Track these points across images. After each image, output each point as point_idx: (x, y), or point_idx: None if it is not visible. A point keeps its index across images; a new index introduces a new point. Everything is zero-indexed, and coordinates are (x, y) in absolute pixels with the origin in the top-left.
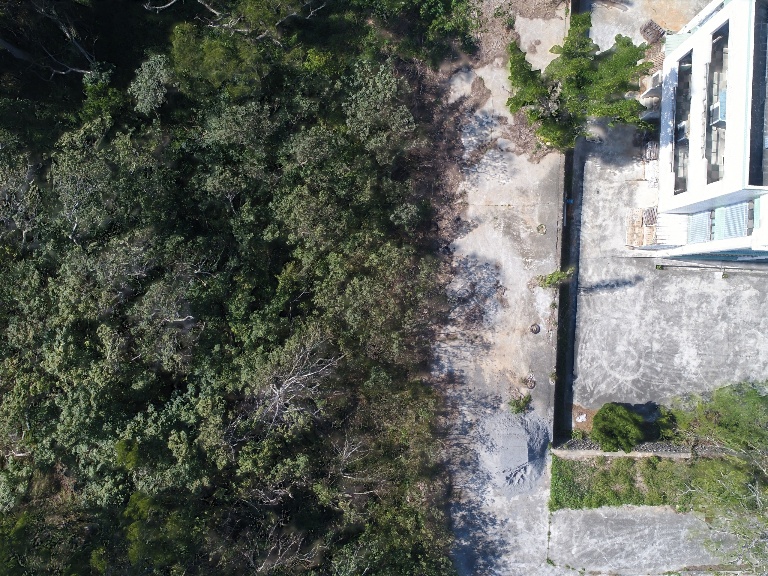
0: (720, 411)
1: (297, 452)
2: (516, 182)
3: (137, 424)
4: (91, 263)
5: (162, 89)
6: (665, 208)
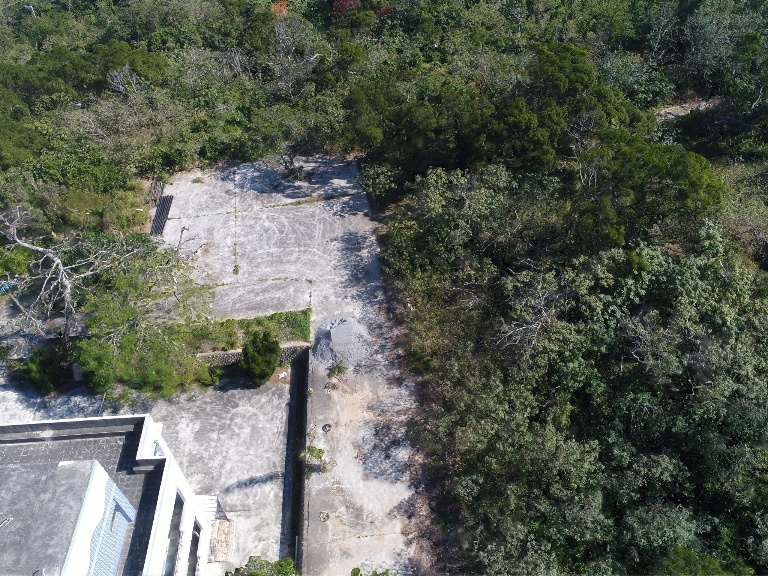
0: (175, 374)
1: None
2: (354, 564)
3: (642, 287)
4: (742, 388)
5: (763, 532)
6: (208, 524)
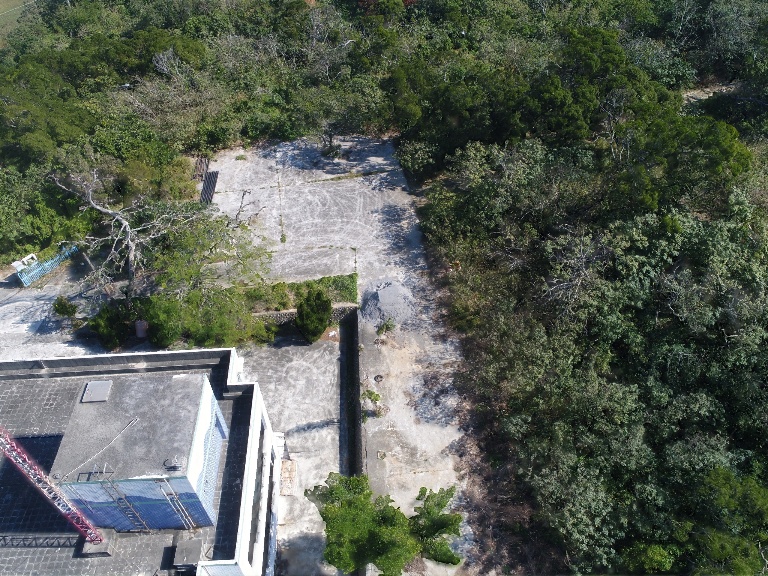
0: (235, 329)
1: (551, 267)
2: (411, 495)
3: (675, 248)
4: None
5: None
6: None
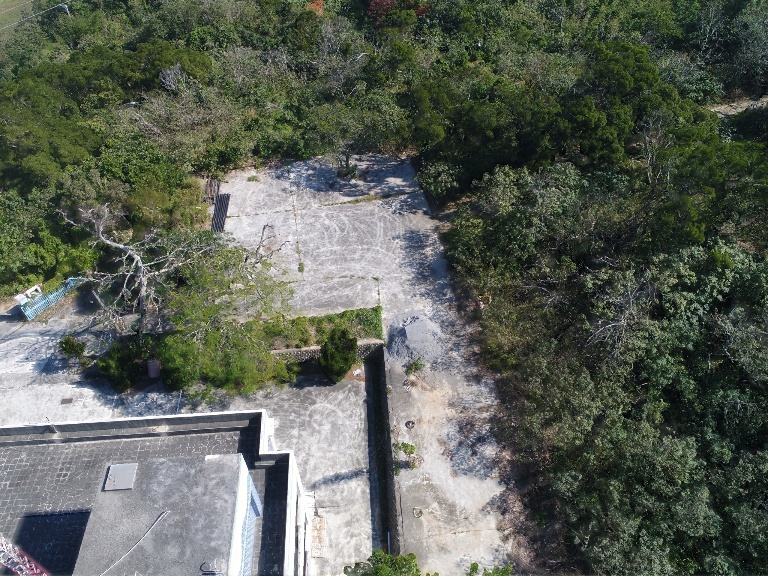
0: (255, 371)
1: (590, 302)
2: (452, 559)
3: (725, 284)
4: None
5: None
6: None
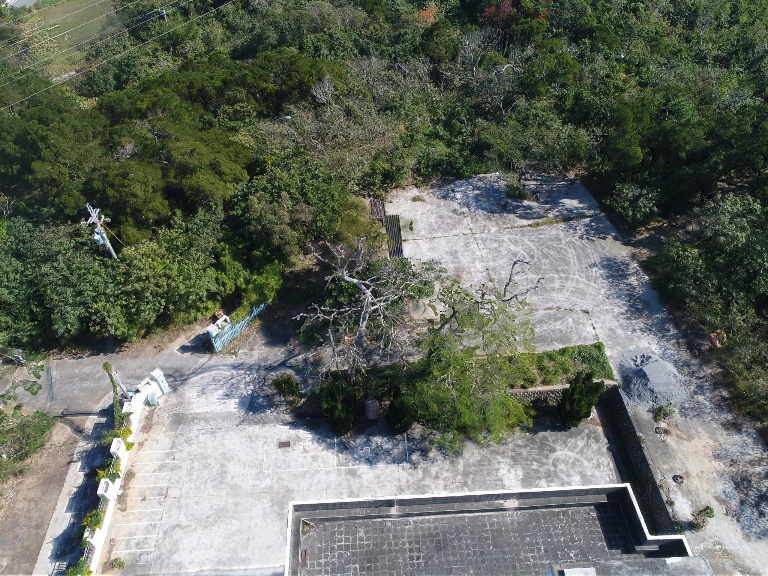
0: None
1: None
2: None
3: None
4: None
5: None
6: None
